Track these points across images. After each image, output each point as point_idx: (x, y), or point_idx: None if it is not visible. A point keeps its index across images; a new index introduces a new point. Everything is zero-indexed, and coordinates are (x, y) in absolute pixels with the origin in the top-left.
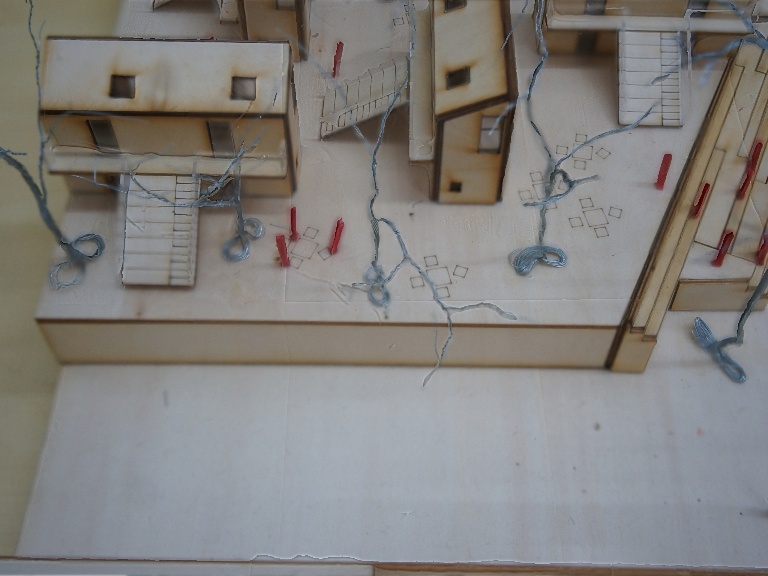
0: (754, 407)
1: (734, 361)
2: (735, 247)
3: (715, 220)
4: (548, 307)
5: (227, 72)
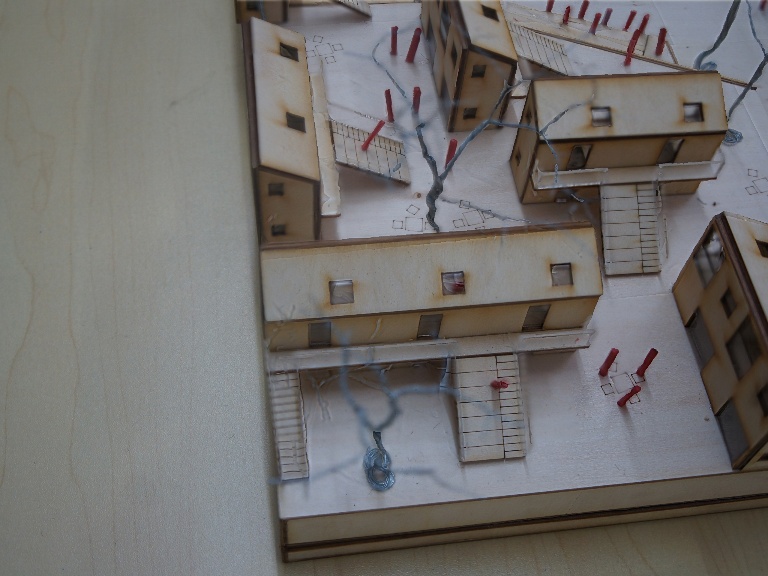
0: (730, 62)
1: (701, 66)
2: (637, 44)
3: (622, 49)
4: (760, 126)
5: (761, 260)
